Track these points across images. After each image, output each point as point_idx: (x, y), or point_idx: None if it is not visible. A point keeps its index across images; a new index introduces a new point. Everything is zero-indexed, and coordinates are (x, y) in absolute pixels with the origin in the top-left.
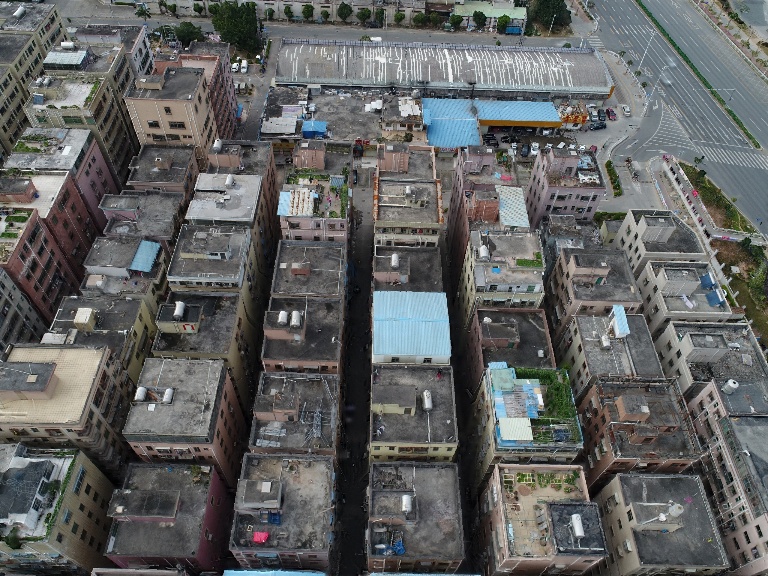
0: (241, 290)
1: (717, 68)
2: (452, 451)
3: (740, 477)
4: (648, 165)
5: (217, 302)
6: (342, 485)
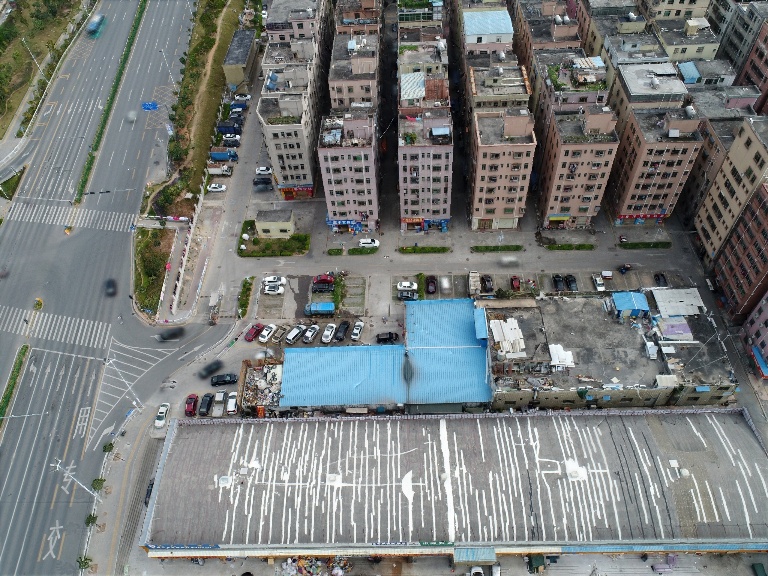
0: None
1: None
2: None
3: None
4: (192, 316)
5: None
6: (511, 19)
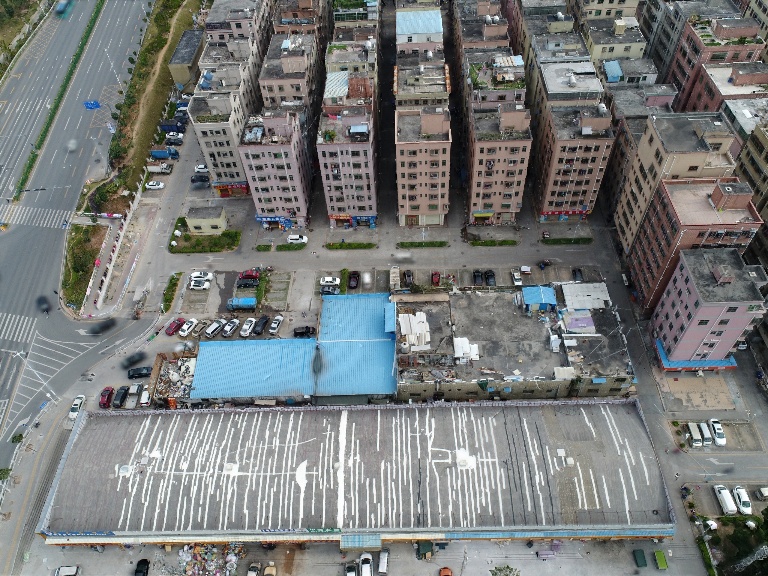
0: None
1: None
2: None
3: None
4: (116, 311)
5: None
6: (450, 19)
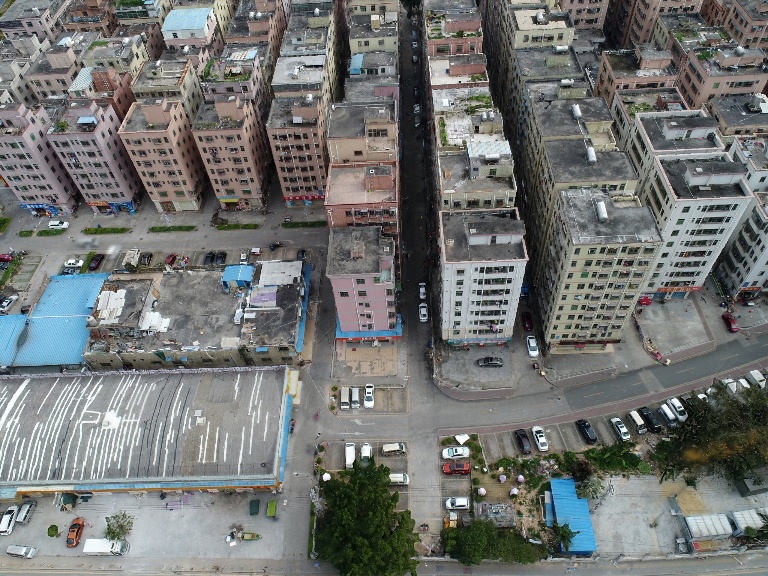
0: None
1: None
2: None
3: (62, 3)
4: None
5: None
6: None
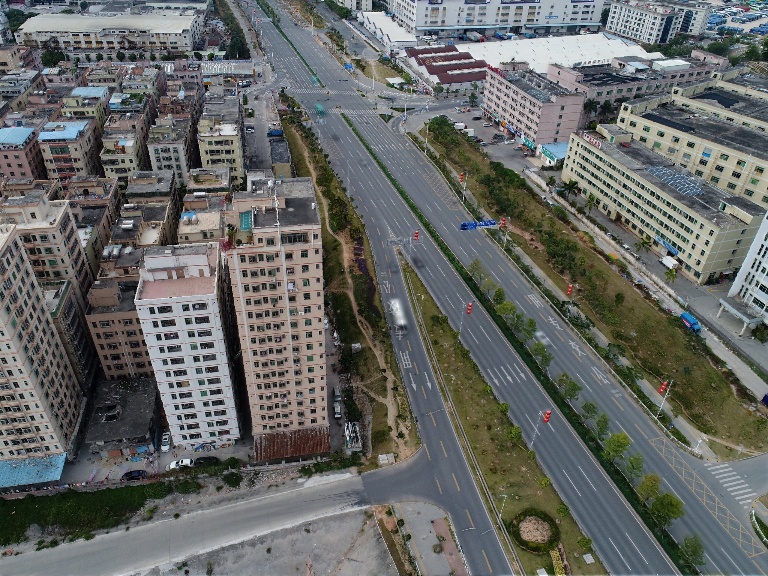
0: (23, 96)
1: (323, 68)
2: (95, 114)
3: None
4: None
5: (11, 97)
6: None
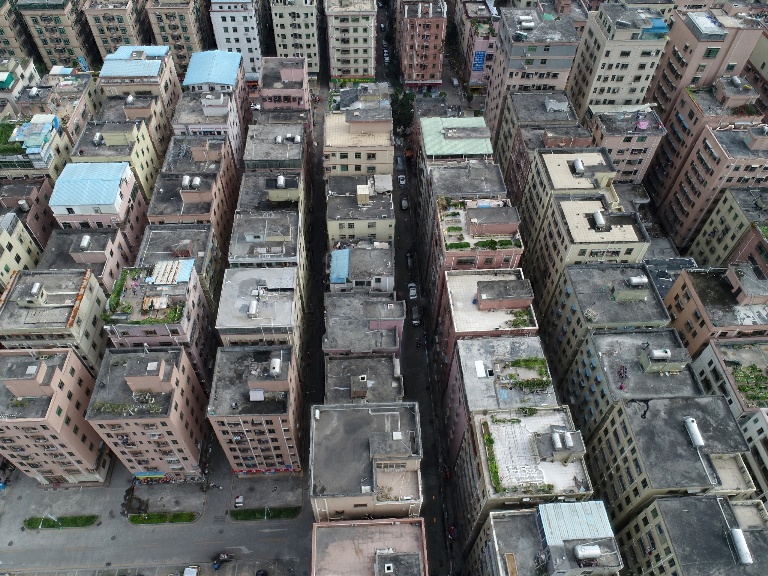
0: None
1: None
2: None
3: None
4: None
5: None
6: None
